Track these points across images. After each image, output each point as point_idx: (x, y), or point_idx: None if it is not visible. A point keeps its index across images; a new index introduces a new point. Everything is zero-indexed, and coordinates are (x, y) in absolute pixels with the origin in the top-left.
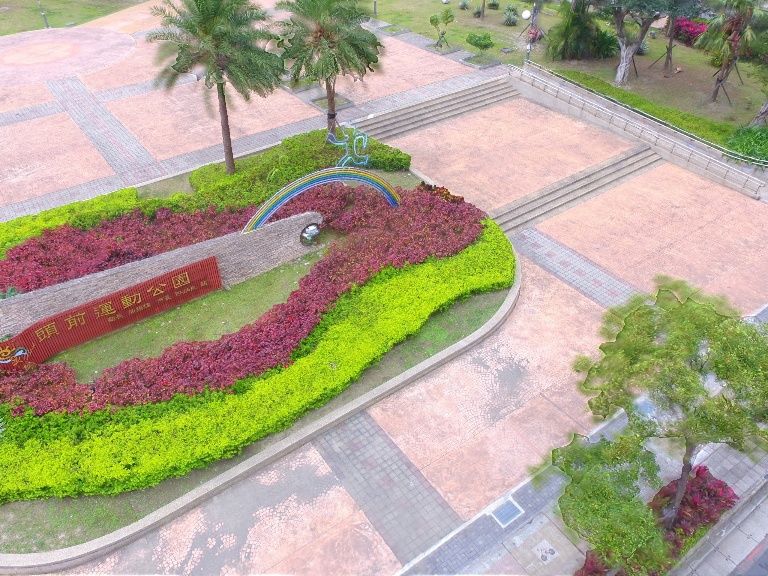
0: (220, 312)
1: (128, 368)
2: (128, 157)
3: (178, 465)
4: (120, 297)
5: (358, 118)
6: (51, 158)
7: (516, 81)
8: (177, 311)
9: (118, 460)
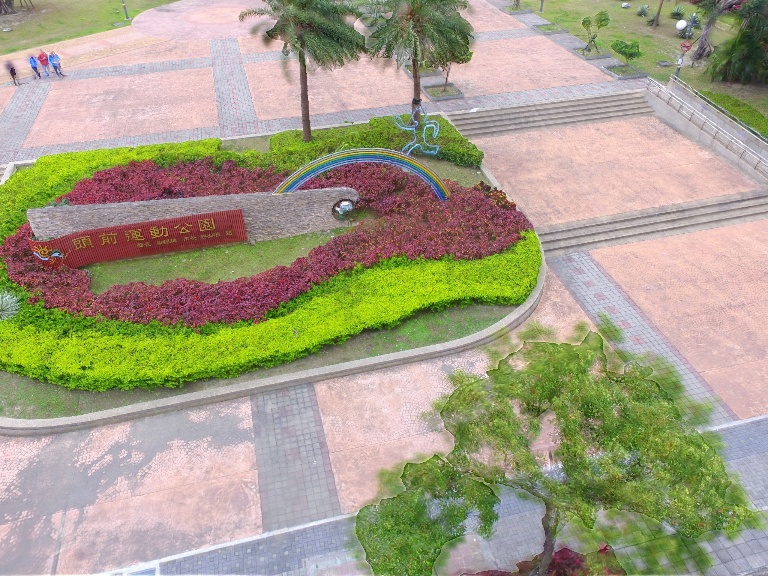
0: (236, 262)
1: (130, 288)
2: (236, 113)
3: (122, 379)
4: (149, 227)
5: (460, 110)
6: (178, 104)
7: (652, 97)
8: (202, 252)
9: (79, 360)
